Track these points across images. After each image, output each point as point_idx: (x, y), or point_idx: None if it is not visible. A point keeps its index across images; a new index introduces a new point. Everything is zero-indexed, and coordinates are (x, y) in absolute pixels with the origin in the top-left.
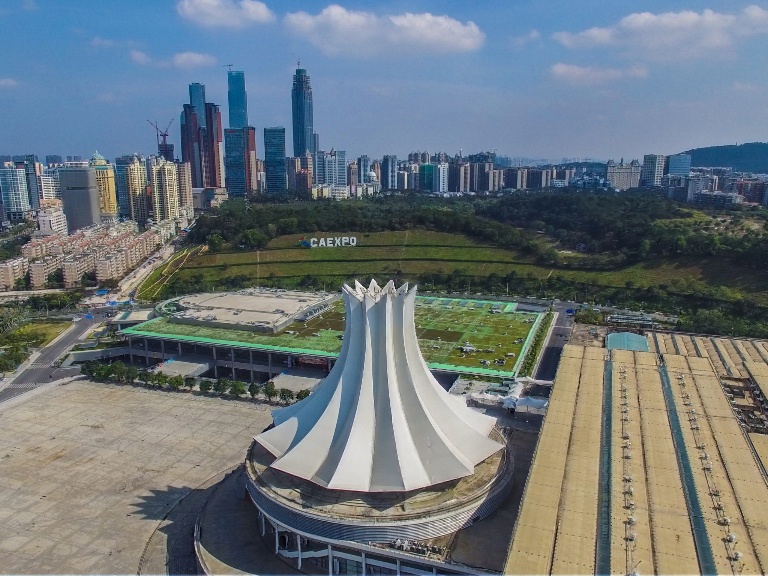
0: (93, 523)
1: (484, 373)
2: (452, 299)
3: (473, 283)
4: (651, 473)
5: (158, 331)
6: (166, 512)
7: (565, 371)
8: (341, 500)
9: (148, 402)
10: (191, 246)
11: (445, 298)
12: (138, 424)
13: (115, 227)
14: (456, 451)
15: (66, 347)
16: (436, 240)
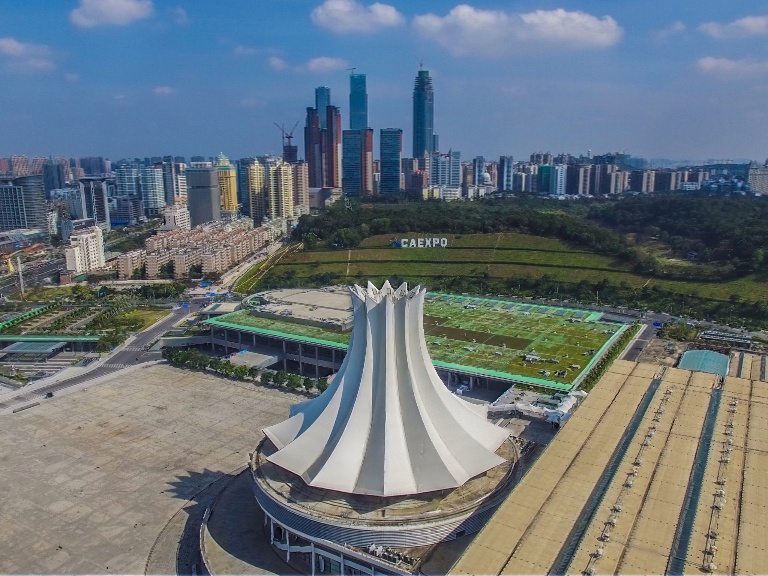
0: (130, 496)
1: (540, 384)
2: (533, 305)
3: (562, 290)
4: (648, 505)
5: (237, 322)
6: (195, 493)
7: (602, 387)
8: (326, 498)
9: (212, 389)
10: (293, 243)
11: (526, 304)
12: (197, 408)
13: (231, 223)
14: (453, 461)
15: (159, 333)
16: (529, 244)
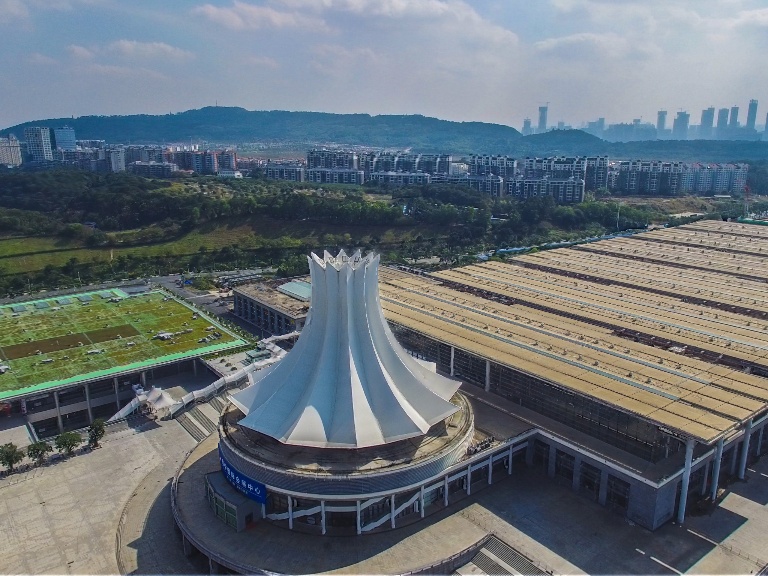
0: None
1: (221, 348)
2: (41, 301)
3: None
4: None
5: None
6: None
7: None
8: (417, 444)
9: None
10: None
11: (28, 302)
12: None
13: None
14: None
15: None
16: None
